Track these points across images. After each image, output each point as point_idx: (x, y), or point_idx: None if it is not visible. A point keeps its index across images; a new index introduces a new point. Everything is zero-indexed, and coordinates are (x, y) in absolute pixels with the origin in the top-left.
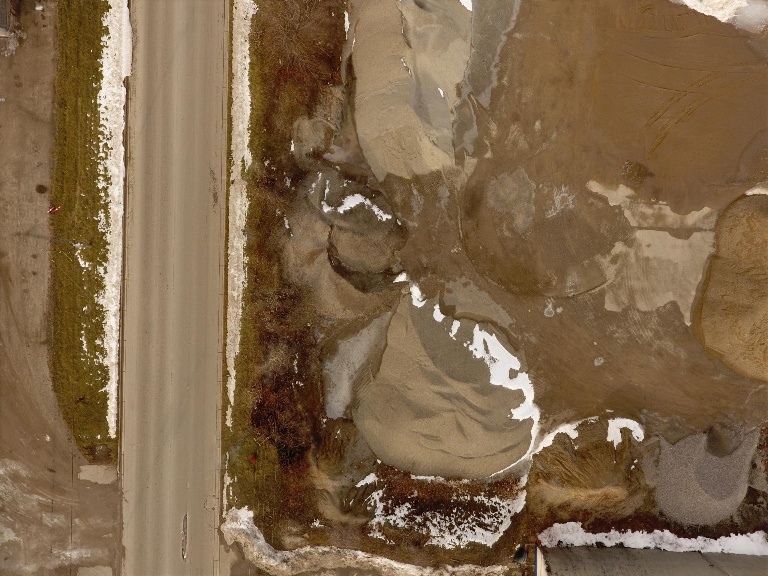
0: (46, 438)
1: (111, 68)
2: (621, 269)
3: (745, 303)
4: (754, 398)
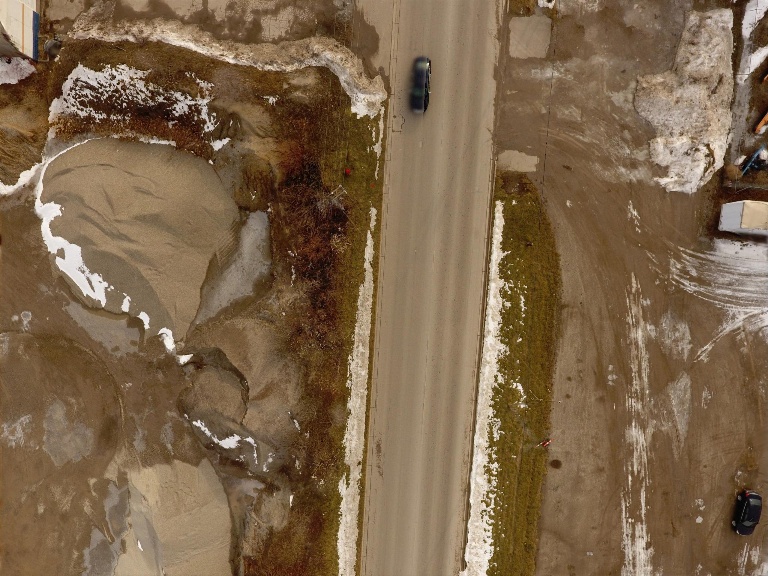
0: (570, 204)
1: None
2: None
3: None
4: None
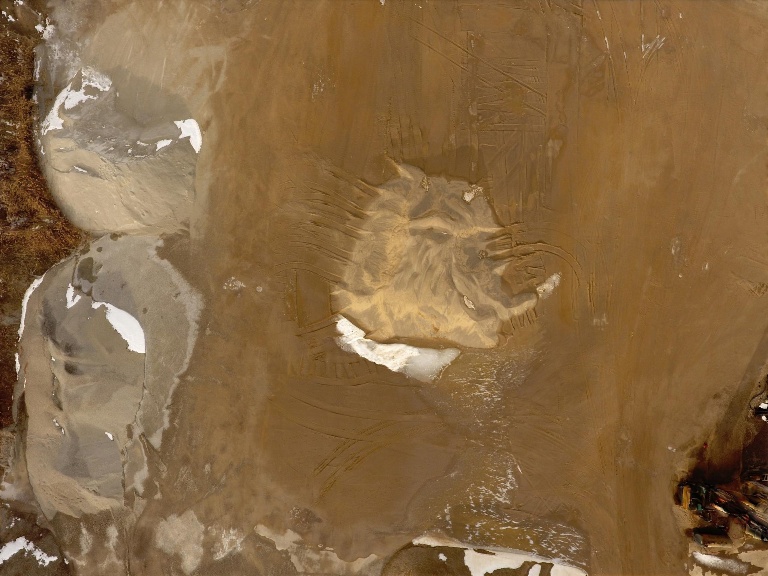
0: None
1: None
2: None
3: None
4: None
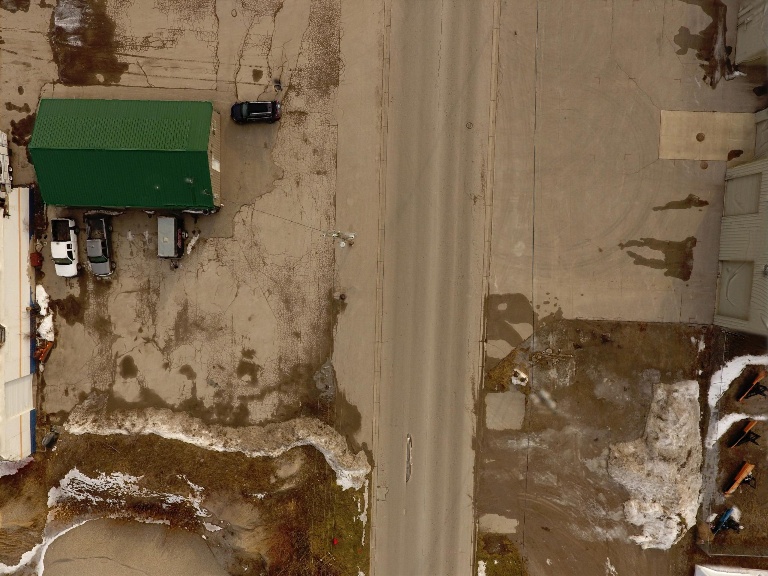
0: (550, 561)
1: None
2: None
3: None
4: None
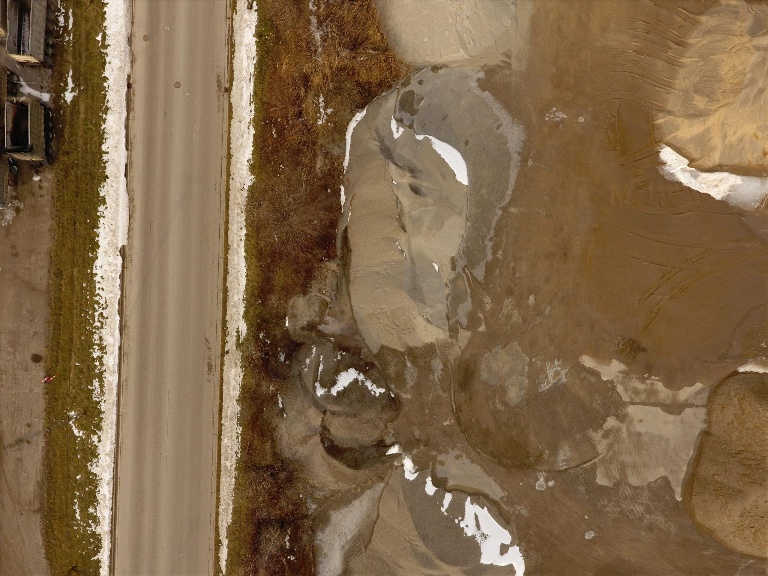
0: None
1: (107, 238)
2: (613, 444)
3: (735, 486)
4: (744, 573)
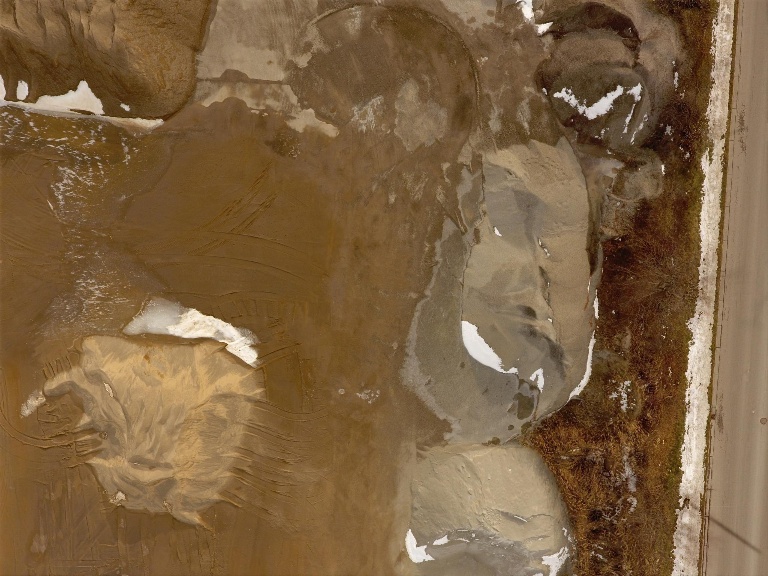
0: None
1: None
2: (300, 36)
3: None
4: None
